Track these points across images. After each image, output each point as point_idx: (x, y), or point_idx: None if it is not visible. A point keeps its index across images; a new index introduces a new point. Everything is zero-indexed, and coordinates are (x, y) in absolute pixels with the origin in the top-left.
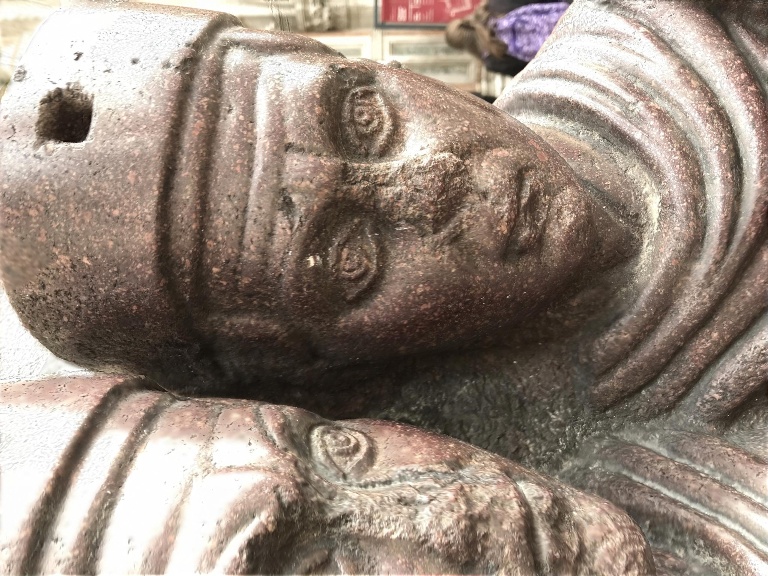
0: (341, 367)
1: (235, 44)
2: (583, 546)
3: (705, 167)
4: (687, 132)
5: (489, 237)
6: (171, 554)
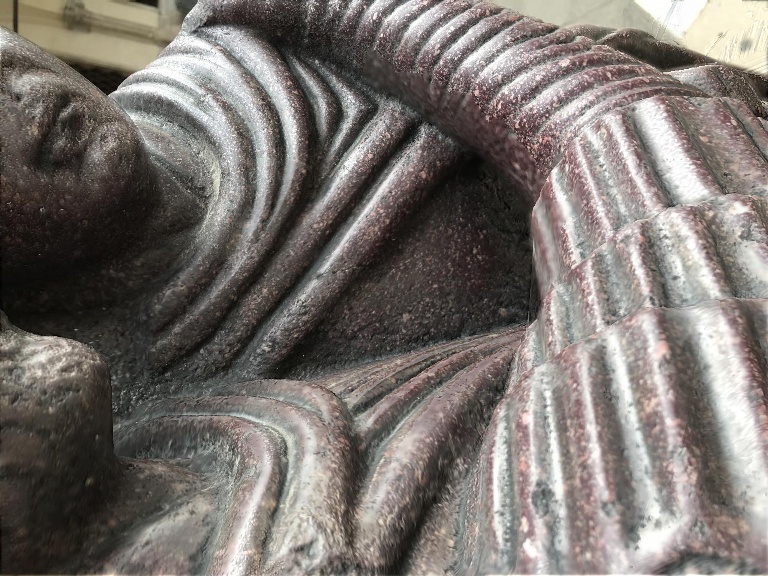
0: None
1: None
2: (17, 349)
3: (257, 146)
4: (245, 119)
5: (17, 135)
6: None
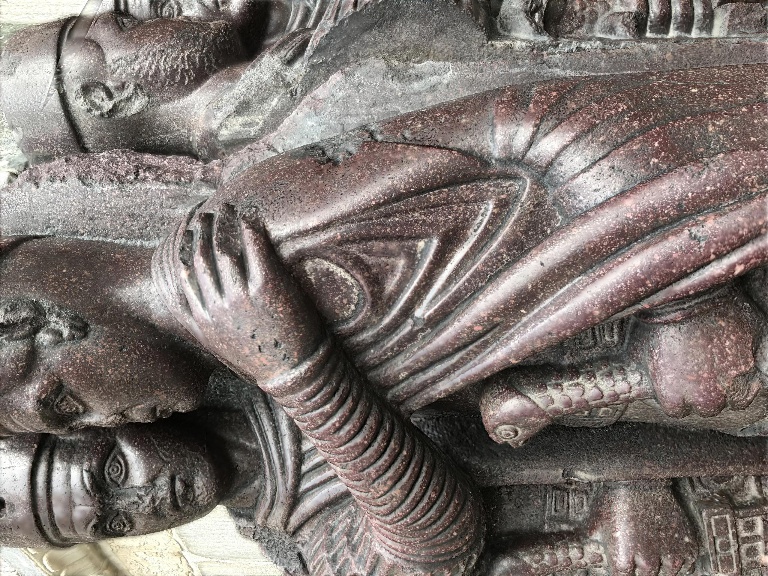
0: None
1: None
2: (194, 496)
3: None
4: None
5: None
6: (75, 527)
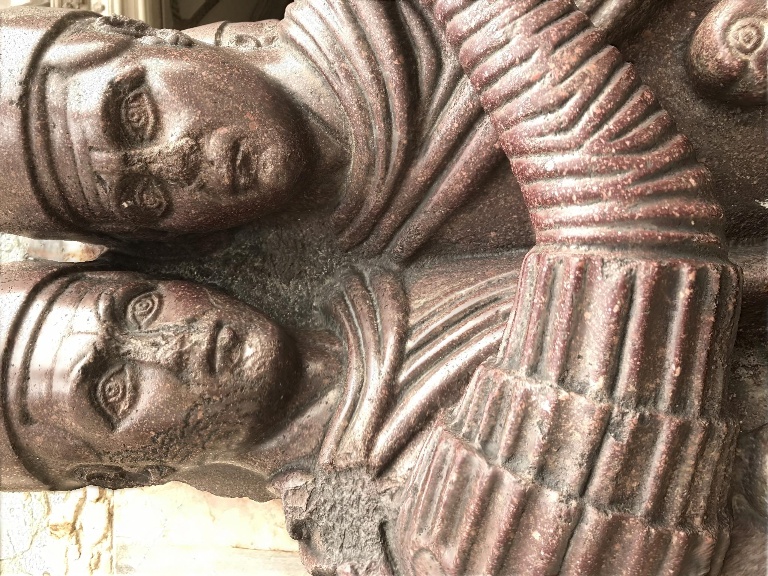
0: (184, 234)
1: (52, 68)
2: (241, 358)
3: (372, 116)
4: (362, 89)
5: (220, 186)
6: (55, 371)
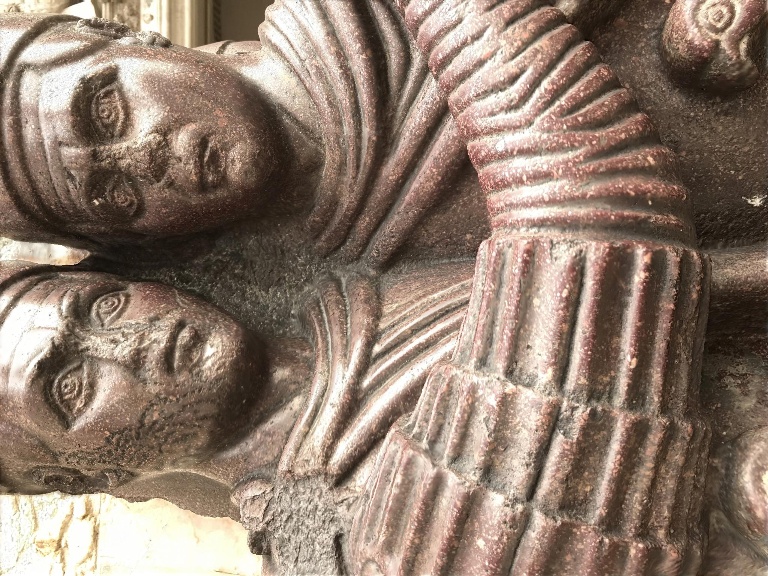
0: (163, 238)
1: (27, 66)
2: (201, 358)
3: (342, 113)
4: (332, 86)
5: (188, 183)
6: (12, 365)
